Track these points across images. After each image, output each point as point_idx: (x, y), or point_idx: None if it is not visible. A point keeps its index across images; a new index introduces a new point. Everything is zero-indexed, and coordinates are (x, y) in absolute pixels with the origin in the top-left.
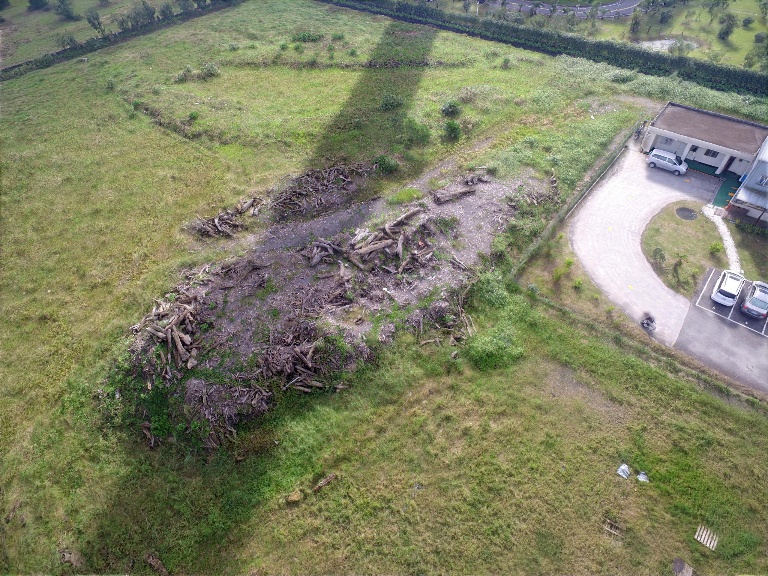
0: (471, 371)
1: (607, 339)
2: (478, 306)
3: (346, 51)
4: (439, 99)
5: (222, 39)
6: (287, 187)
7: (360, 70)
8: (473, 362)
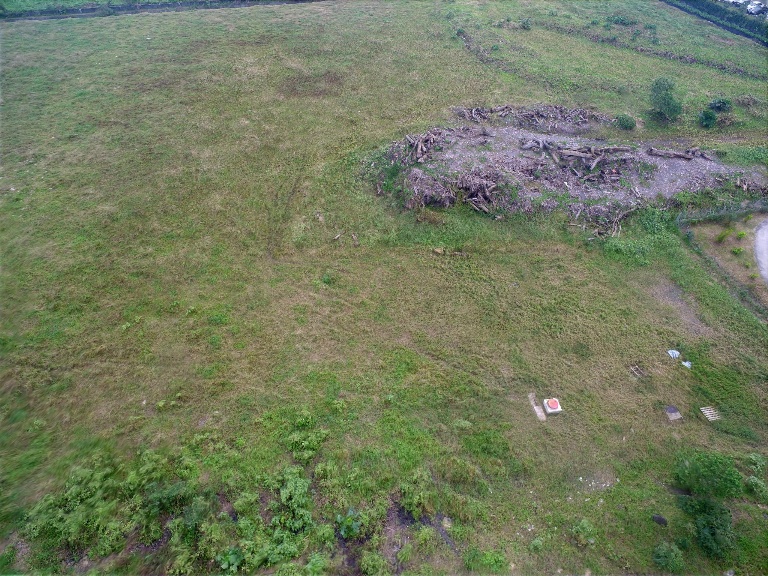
0: (597, 254)
1: (733, 291)
2: (633, 225)
3: (649, 39)
4: (714, 96)
5: (547, 6)
6: (535, 109)
7: (653, 56)
8: (602, 250)
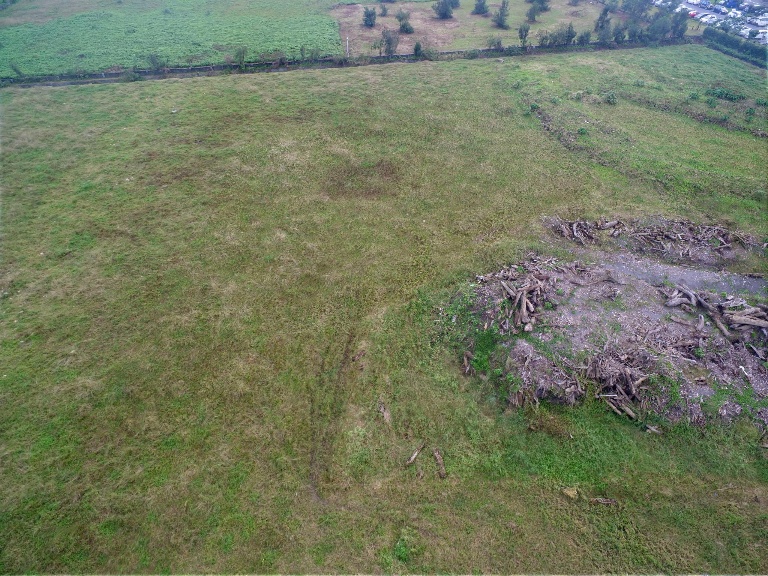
0: None
1: None
2: None
3: None
4: None
5: (628, 74)
6: (655, 225)
7: None
8: None
